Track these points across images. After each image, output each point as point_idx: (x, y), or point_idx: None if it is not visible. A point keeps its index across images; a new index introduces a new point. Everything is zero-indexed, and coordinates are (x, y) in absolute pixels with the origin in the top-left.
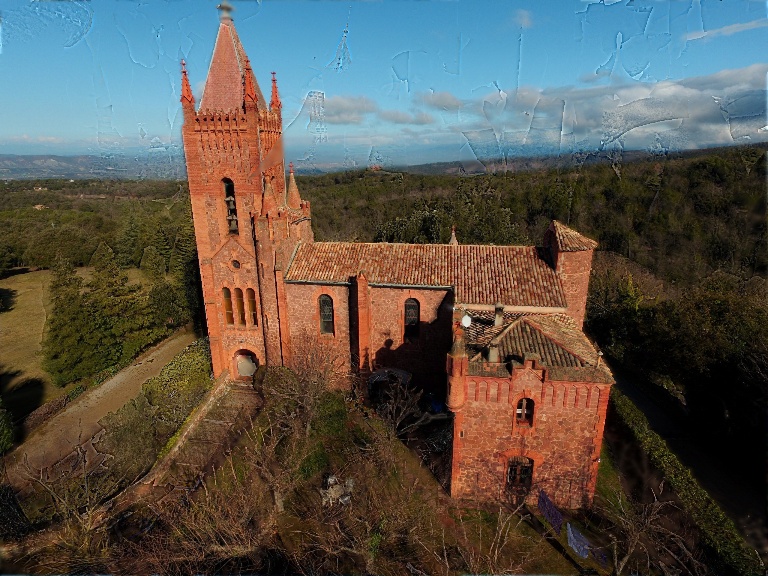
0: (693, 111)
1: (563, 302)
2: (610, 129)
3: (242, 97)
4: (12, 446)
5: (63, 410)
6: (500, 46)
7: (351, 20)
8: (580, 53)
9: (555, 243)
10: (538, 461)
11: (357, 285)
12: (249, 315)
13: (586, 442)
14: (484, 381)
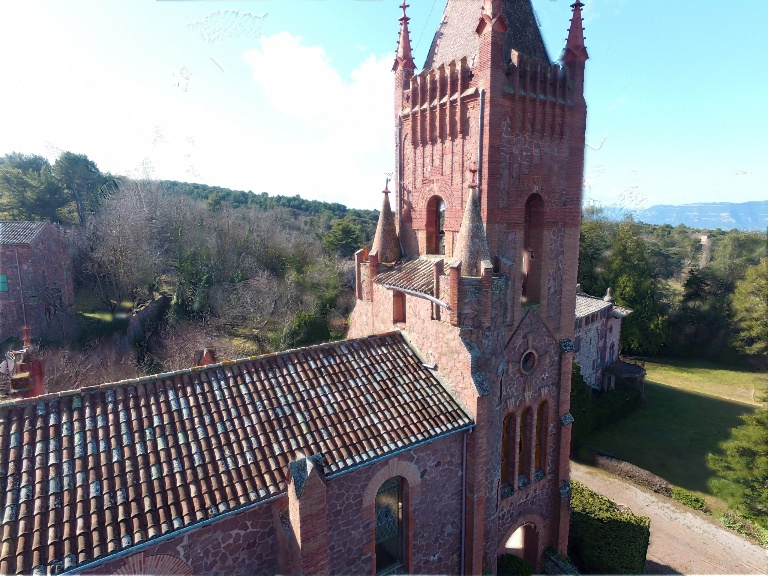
0: None
1: None
2: None
3: None
4: (575, 458)
5: (646, 490)
6: None
7: None
8: None
9: None
10: None
11: None
12: None
13: None
14: None
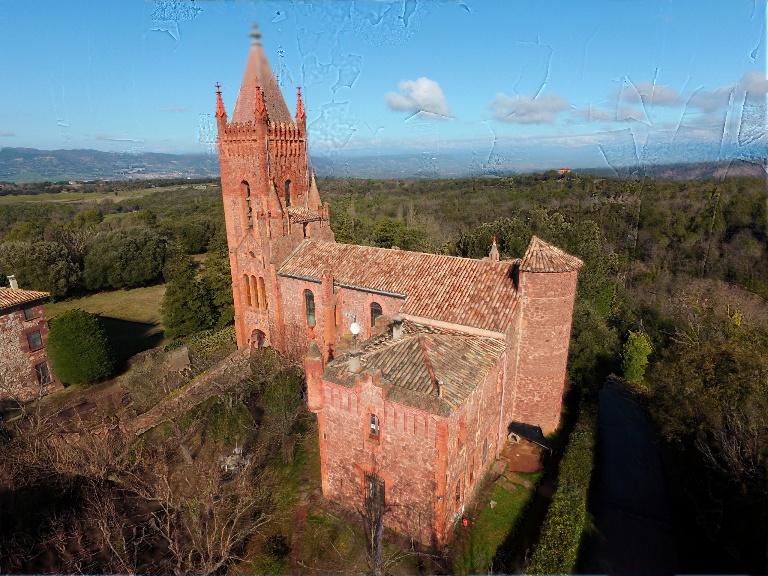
0: None
1: (503, 327)
2: (753, 127)
3: None
4: (115, 375)
5: None
6: (636, 33)
7: (284, 41)
8: (750, 31)
9: None
10: (388, 482)
11: None
12: (262, 300)
13: (429, 475)
14: (337, 388)
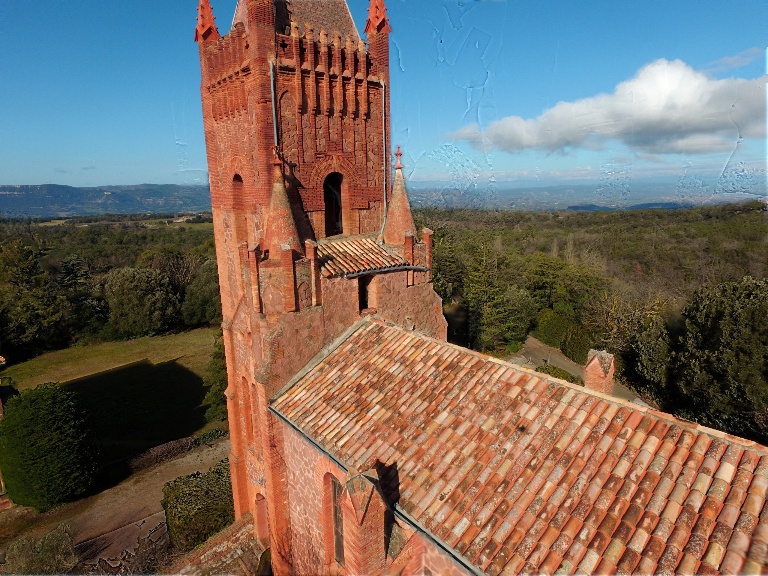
0: None
1: None
2: None
3: None
4: (104, 486)
5: (183, 455)
6: None
7: None
8: None
9: None
10: None
11: None
12: None
13: None
14: None
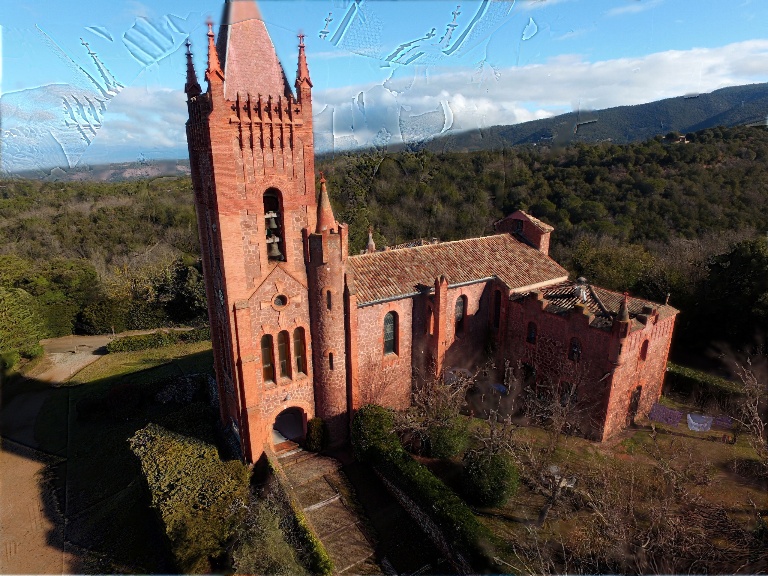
0: (461, 124)
1: (565, 272)
2: (411, 135)
3: (282, 81)
4: None
5: None
6: (284, 48)
7: None
8: (348, 65)
9: (532, 228)
10: (644, 385)
11: (437, 292)
12: (294, 362)
13: (662, 360)
14: (630, 336)
